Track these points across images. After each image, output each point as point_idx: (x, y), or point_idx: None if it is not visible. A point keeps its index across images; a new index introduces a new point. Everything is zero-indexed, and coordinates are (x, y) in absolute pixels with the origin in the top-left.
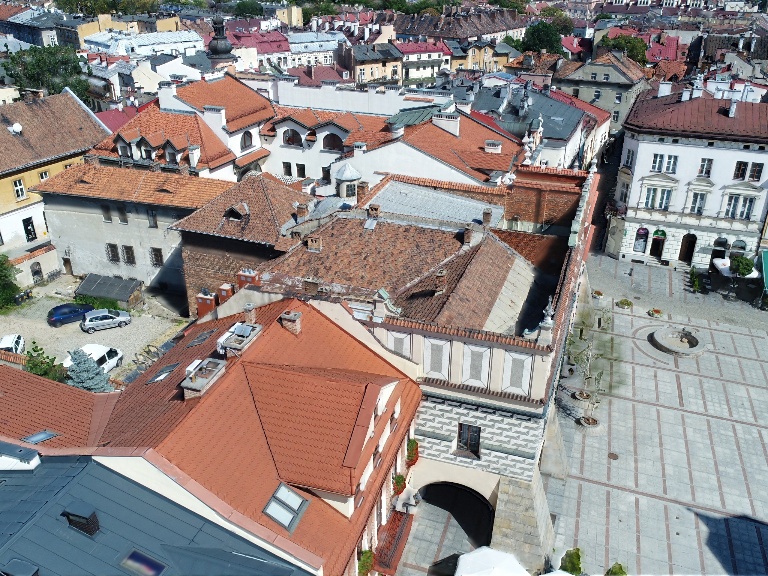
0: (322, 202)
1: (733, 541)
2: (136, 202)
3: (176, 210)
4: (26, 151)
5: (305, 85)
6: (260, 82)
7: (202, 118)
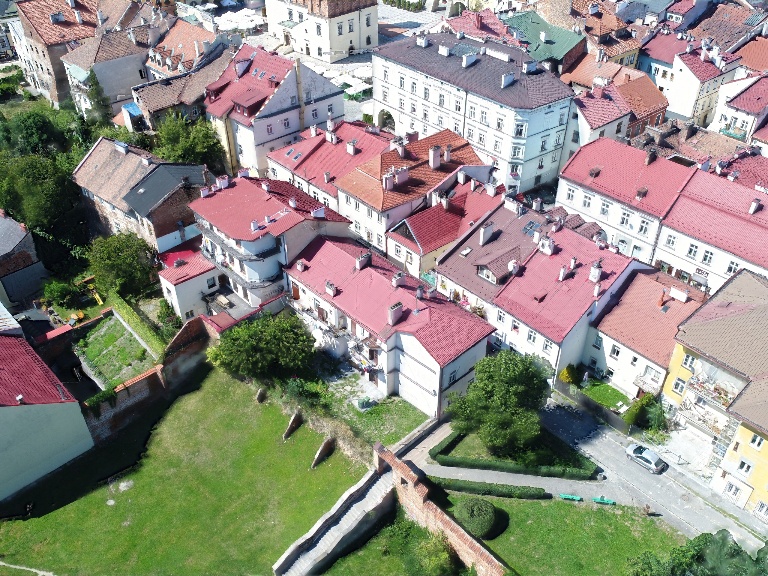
0: None
1: None
2: None
3: None
4: None
5: None
6: None
7: None
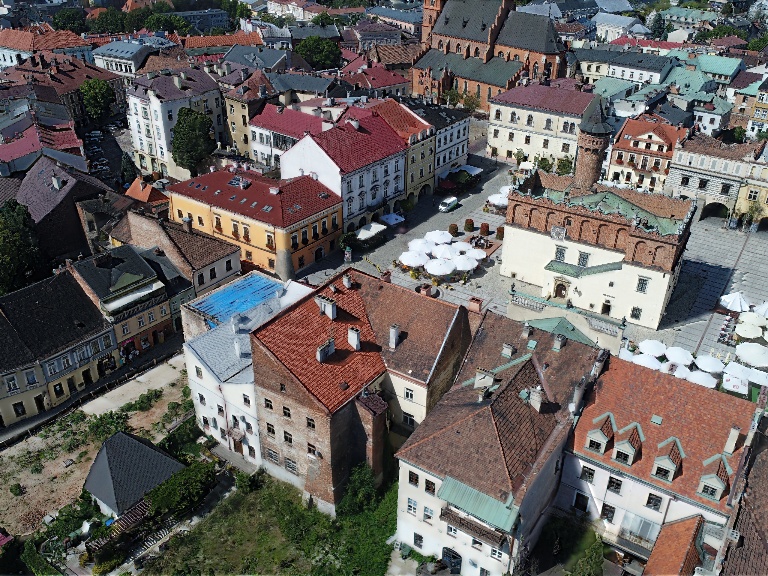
0: None
1: None
2: None
3: None
4: None
5: None
6: None
7: None
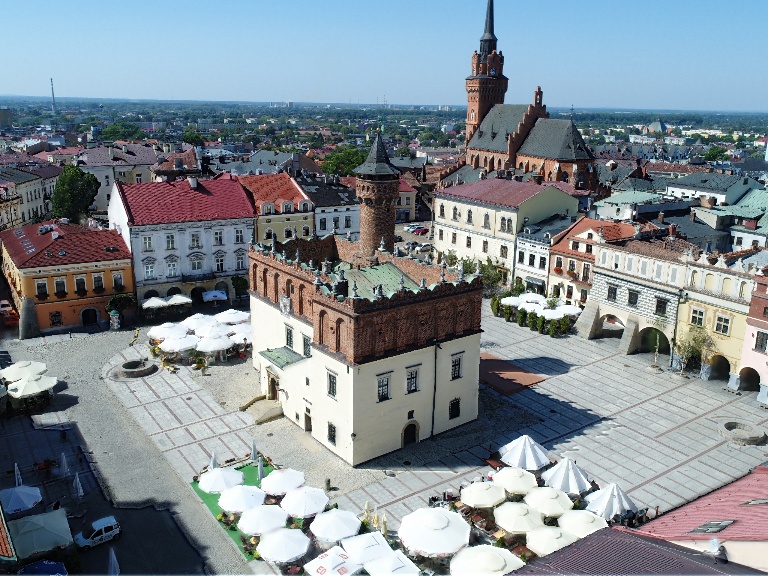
0: None
1: (558, 364)
2: None
3: None
4: None
5: None
6: None
7: None
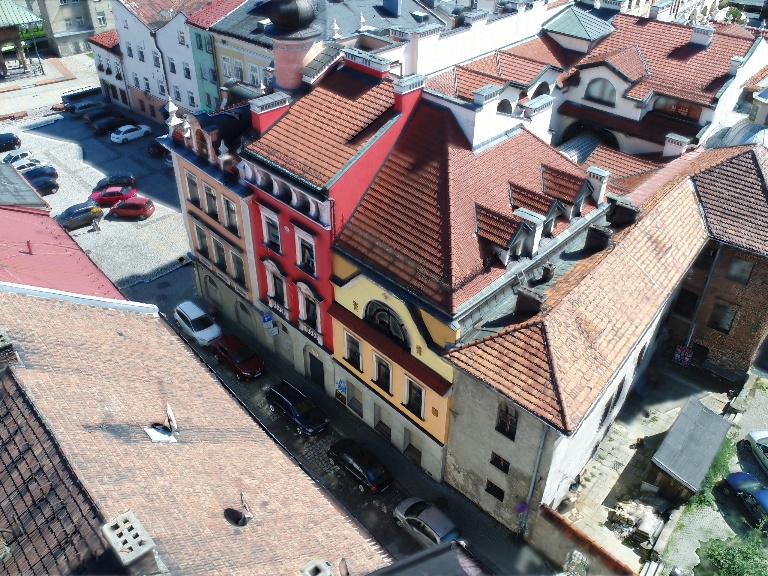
0: (765, 141)
1: None
2: (672, 292)
3: (693, 263)
4: (240, 445)
5: (453, 31)
6: (391, 52)
7: (528, 129)
